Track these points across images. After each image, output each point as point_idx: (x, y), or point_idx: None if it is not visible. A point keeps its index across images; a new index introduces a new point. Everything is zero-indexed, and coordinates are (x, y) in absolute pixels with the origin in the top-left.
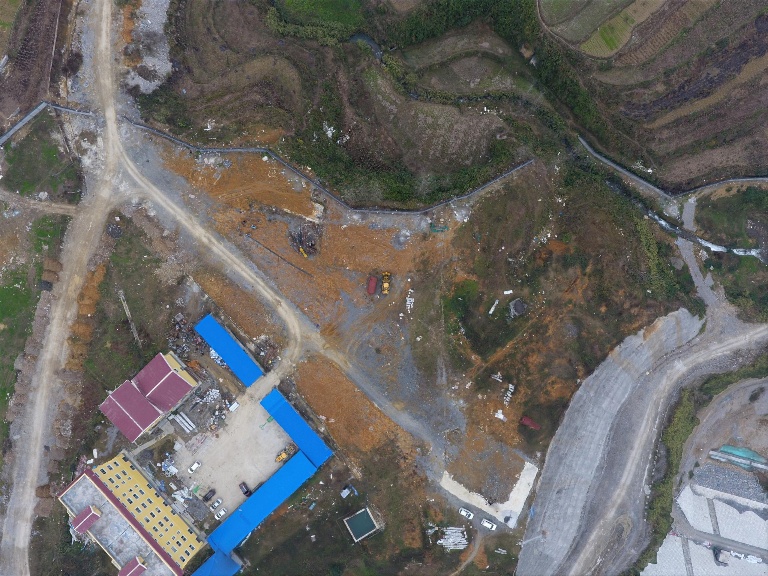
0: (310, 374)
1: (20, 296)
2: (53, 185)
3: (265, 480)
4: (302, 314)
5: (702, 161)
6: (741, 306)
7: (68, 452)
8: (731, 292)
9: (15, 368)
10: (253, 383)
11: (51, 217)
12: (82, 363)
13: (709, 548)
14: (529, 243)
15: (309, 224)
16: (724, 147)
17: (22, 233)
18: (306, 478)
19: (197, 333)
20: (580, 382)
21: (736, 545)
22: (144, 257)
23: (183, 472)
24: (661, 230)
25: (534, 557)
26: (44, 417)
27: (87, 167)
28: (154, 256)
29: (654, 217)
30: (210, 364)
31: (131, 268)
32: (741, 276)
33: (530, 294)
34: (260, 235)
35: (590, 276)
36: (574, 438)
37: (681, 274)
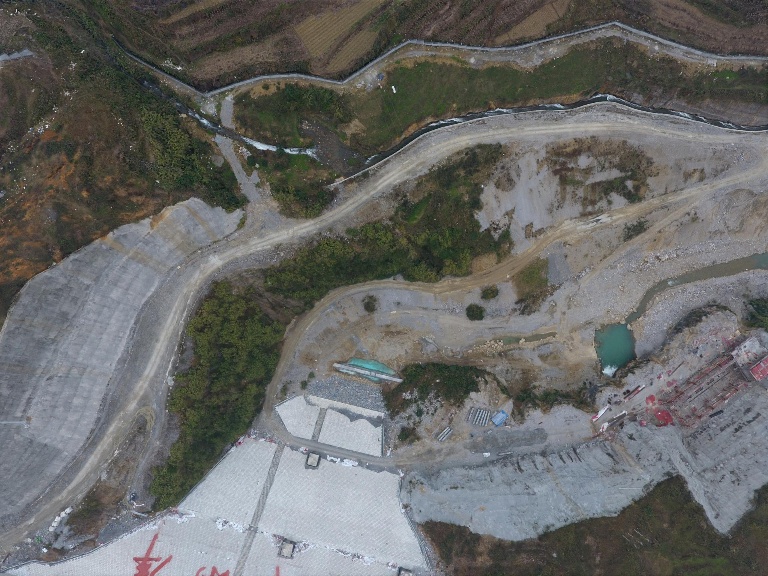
0: None
1: None
2: None
3: None
4: None
5: (232, 58)
6: (279, 201)
7: None
8: (273, 188)
9: None
10: None
11: None
12: None
13: (305, 453)
14: (20, 133)
15: None
16: (254, 44)
17: None
18: None
19: None
20: (54, 265)
21: (333, 450)
22: None
23: None
24: (198, 128)
25: (18, 443)
26: None
27: None
28: None
29: (195, 116)
30: None
31: None
32: (292, 174)
33: (11, 181)
34: None
35: (76, 163)
36: (67, 325)
37: (222, 171)
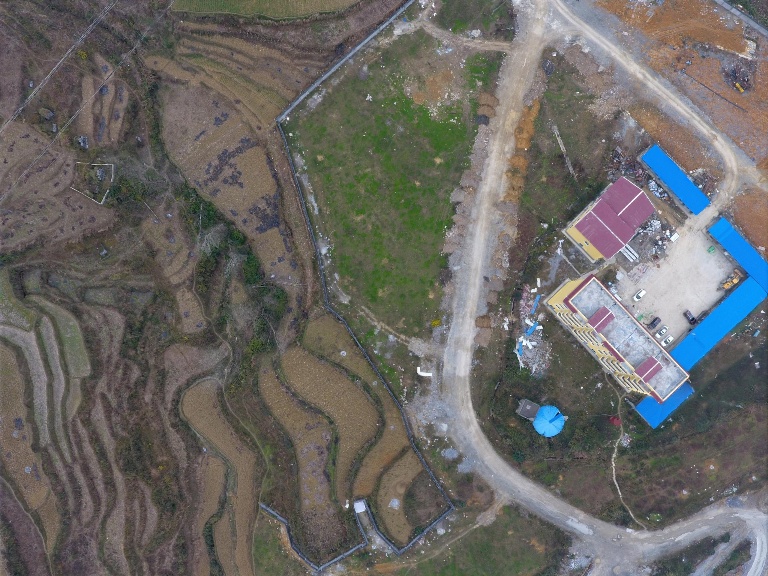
0: (748, 206)
1: (456, 131)
2: (485, 23)
3: (707, 309)
4: (738, 148)
5: None
6: None
7: (506, 283)
8: None
9: (452, 201)
10: (693, 214)
11: (484, 54)
12: (519, 196)
13: None
14: None
15: (742, 61)
16: None
17: (456, 70)
18: (757, 303)
19: (637, 165)
20: None
21: None
22: (576, 94)
23: (626, 301)
24: None
25: None
26: (484, 248)
27: (518, 6)
28: (586, 93)
29: None
30: (649, 196)
31: (564, 104)
32: None
33: None
34: (694, 71)
35: None
36: None
37: None
